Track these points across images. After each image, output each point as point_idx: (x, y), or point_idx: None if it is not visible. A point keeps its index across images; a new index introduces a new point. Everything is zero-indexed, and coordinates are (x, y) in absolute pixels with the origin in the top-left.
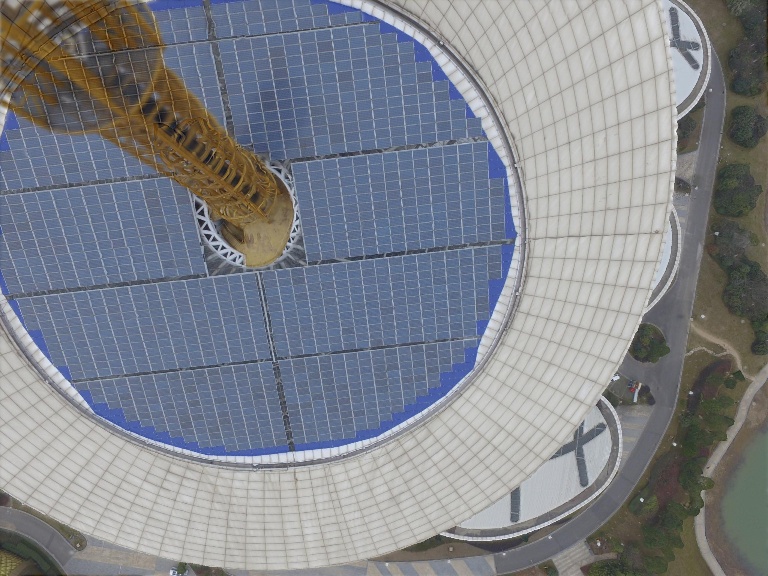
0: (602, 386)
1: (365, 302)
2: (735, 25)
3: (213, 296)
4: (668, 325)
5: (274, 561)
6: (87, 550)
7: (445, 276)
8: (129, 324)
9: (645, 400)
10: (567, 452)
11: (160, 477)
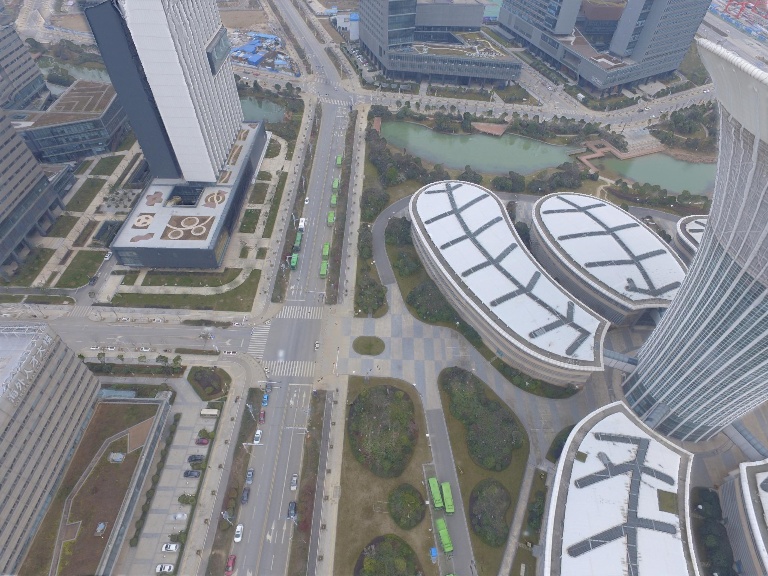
0: None
1: None
2: (408, 182)
3: None
4: None
5: None
6: None
7: None
8: None
9: (650, 220)
10: None
11: None
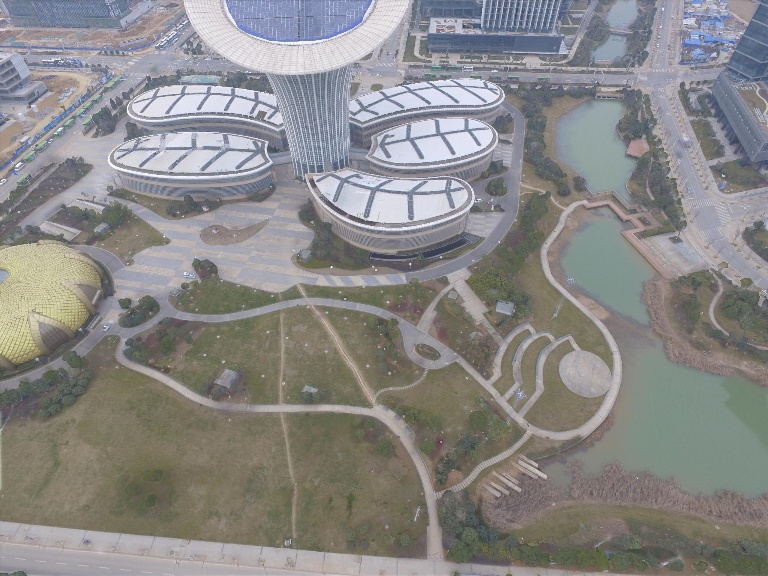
0: (400, 17)
1: (329, 5)
2: (524, 101)
3: (285, 2)
4: (508, 184)
5: (284, 69)
6: (132, 266)
7: (353, 1)
8: (258, 7)
9: (498, 210)
10: (441, 193)
11: (252, 43)
